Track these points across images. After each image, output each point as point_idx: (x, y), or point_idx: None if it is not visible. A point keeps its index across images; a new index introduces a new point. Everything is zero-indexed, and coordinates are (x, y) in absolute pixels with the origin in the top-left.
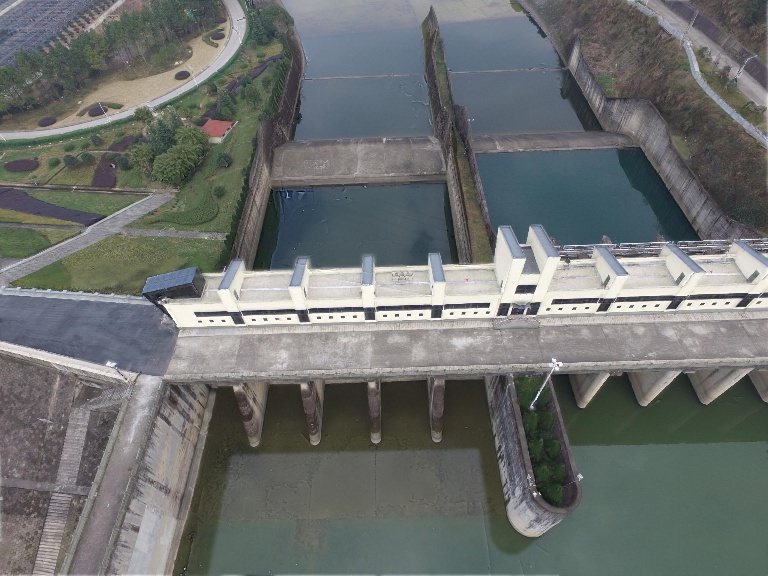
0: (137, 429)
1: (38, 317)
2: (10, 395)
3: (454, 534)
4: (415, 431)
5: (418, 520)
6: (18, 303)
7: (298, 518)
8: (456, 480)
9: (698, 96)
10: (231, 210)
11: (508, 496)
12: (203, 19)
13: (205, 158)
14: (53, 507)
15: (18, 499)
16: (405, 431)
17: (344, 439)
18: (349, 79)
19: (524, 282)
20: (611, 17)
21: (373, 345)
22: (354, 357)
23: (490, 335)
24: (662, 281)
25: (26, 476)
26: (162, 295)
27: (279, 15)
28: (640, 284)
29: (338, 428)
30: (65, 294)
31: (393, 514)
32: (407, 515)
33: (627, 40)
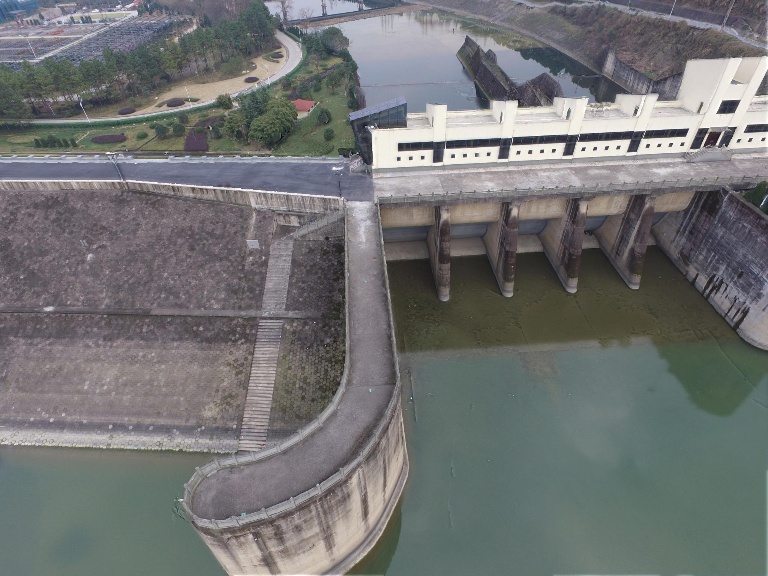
0: (366, 233)
1: (217, 173)
2: (201, 232)
3: (692, 356)
4: (608, 283)
5: (649, 347)
6: (191, 166)
7: (519, 351)
8: (671, 315)
9: (759, 51)
10: (346, 145)
11: (742, 312)
12: (262, 43)
13: (295, 127)
14: (262, 333)
15: (221, 328)
16: (598, 283)
17: (537, 292)
18: (405, 85)
19: (729, 96)
20: (638, 29)
21: (576, 175)
22: (563, 183)
23: (687, 166)
24: None
25: (227, 306)
26: (368, 125)
27: (337, 35)
28: None
29: (527, 284)
30: (239, 159)
31: (620, 343)
32: (635, 343)
33: (658, 44)
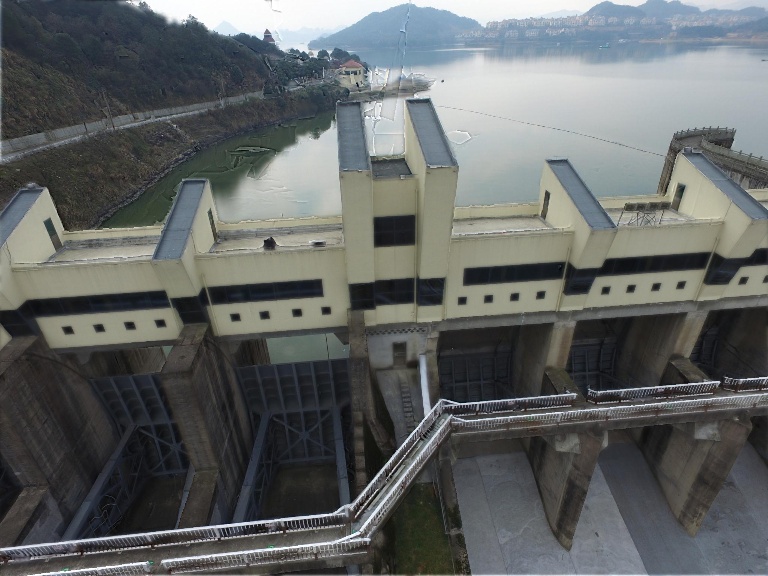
0: None
1: None
2: None
3: None
4: None
5: None
6: None
7: None
8: None
9: None
10: None
11: None
12: None
13: None
14: None
15: None
16: None
17: None
18: None
19: None
20: None
21: None
22: None
23: None
24: (82, 254)
25: None
26: None
27: None
28: (136, 249)
29: None
30: None
31: None
32: None
33: None
